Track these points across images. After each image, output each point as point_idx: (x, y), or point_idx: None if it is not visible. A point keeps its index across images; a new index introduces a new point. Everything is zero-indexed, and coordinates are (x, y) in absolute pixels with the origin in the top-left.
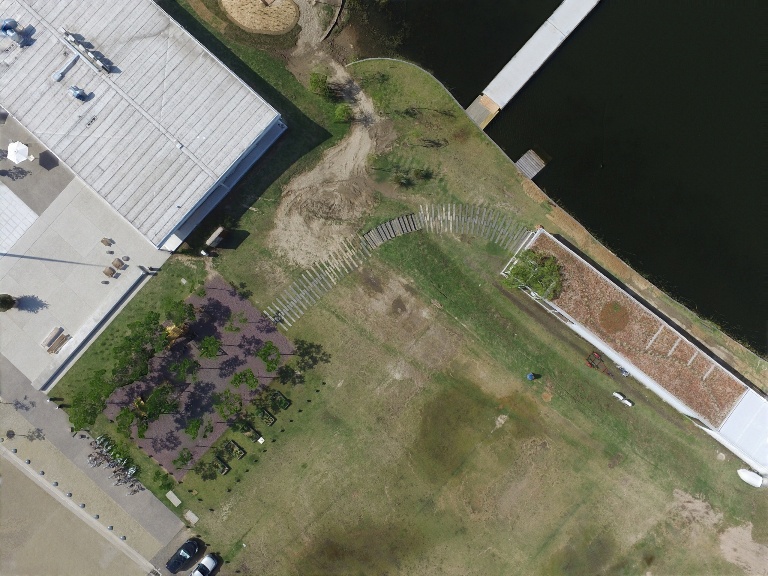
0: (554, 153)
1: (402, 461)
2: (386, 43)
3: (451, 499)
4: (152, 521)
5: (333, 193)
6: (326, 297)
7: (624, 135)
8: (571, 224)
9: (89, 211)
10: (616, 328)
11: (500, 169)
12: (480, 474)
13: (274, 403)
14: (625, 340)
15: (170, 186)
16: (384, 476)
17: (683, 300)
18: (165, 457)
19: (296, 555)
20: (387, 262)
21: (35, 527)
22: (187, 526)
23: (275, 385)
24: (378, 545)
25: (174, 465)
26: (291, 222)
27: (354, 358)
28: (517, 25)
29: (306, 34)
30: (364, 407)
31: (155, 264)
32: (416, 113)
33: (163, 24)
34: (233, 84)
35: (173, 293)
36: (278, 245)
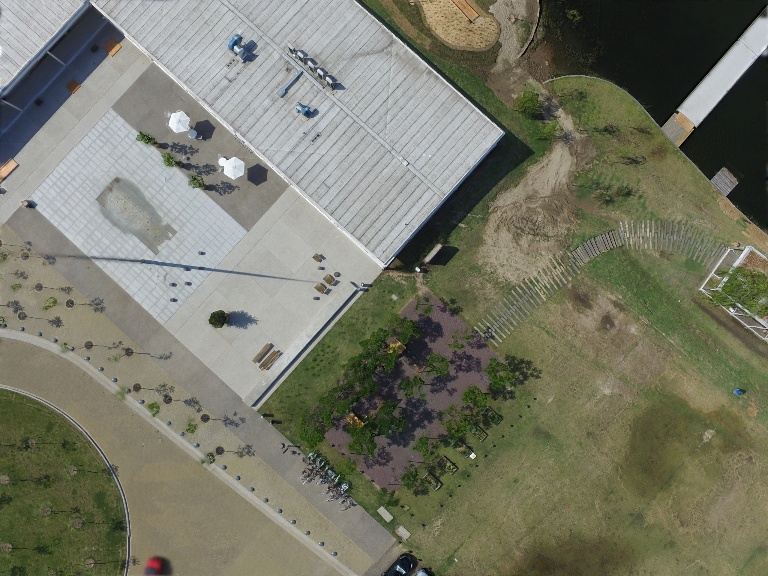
0: (745, 171)
1: (612, 476)
2: (581, 60)
3: (660, 513)
4: (363, 537)
5: (536, 209)
6: (536, 313)
7: None
8: (765, 241)
9: (299, 227)
10: None
11: (697, 186)
12: (688, 488)
13: (485, 419)
14: None
15: (396, 203)
16: (594, 491)
17: None
18: (377, 473)
19: (508, 569)
20: (596, 279)
21: (245, 543)
22: (399, 541)
23: None
24: (589, 559)
25: (386, 481)
26: (500, 238)
27: (564, 374)
28: (708, 44)
29: (505, 51)
30: (574, 422)
31: (366, 280)
32: (615, 130)
33: (386, 41)
34: (457, 102)
35: (384, 309)
36: (487, 261)
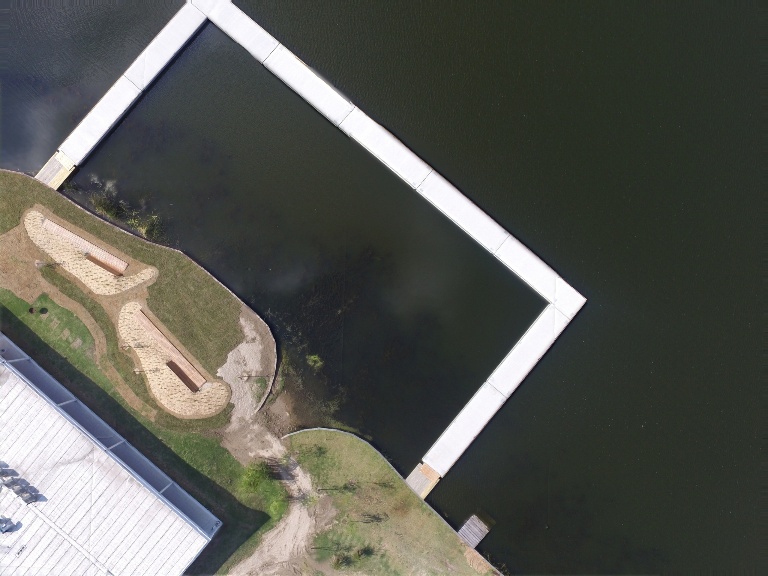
0: (498, 516)
1: None
2: (323, 409)
3: None
4: None
5: (273, 575)
6: None
7: (569, 494)
8: None
9: None
10: None
11: (442, 541)
12: None
13: None
14: None
15: None
16: None
17: None
18: None
19: None
20: None
21: None
22: None
23: None
24: None
25: None
26: None
27: None
28: (456, 384)
29: (240, 409)
30: None
31: None
32: (355, 488)
33: (87, 448)
34: (161, 510)
35: None
36: None
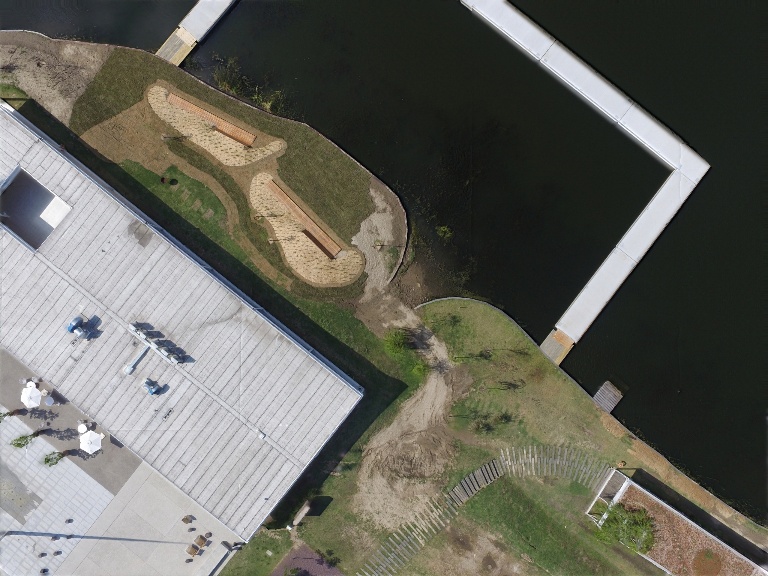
0: (630, 381)
1: None
2: (454, 279)
3: None
4: None
5: (412, 445)
6: (415, 559)
7: (699, 358)
8: (652, 456)
9: (166, 488)
10: (709, 575)
11: (579, 406)
12: None
13: None
14: None
15: (255, 477)
16: None
17: (767, 524)
18: None
19: None
20: (474, 519)
21: None
22: None
23: None
24: None
25: None
26: (374, 484)
27: None
28: (586, 252)
29: (373, 280)
30: None
31: (239, 539)
32: (491, 355)
33: (234, 307)
34: (312, 367)
35: (259, 565)
36: (363, 509)
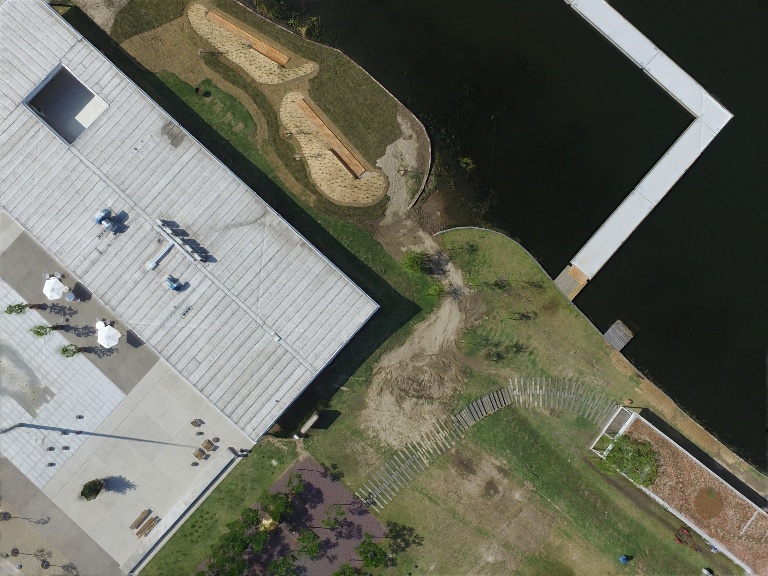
0: (641, 322)
1: None
2: (473, 210)
3: None
4: None
5: (423, 368)
6: (418, 479)
7: (711, 304)
8: (659, 397)
9: (178, 390)
10: (710, 514)
11: (589, 342)
12: None
13: None
14: (719, 526)
15: (268, 379)
16: None
17: None
18: None
19: None
20: (480, 443)
21: None
22: None
23: (367, 568)
24: None
25: None
26: (383, 402)
27: (447, 541)
28: (604, 192)
29: (394, 203)
30: None
31: (246, 445)
32: (505, 285)
33: (259, 212)
34: (331, 275)
35: (263, 474)
36: (370, 425)
